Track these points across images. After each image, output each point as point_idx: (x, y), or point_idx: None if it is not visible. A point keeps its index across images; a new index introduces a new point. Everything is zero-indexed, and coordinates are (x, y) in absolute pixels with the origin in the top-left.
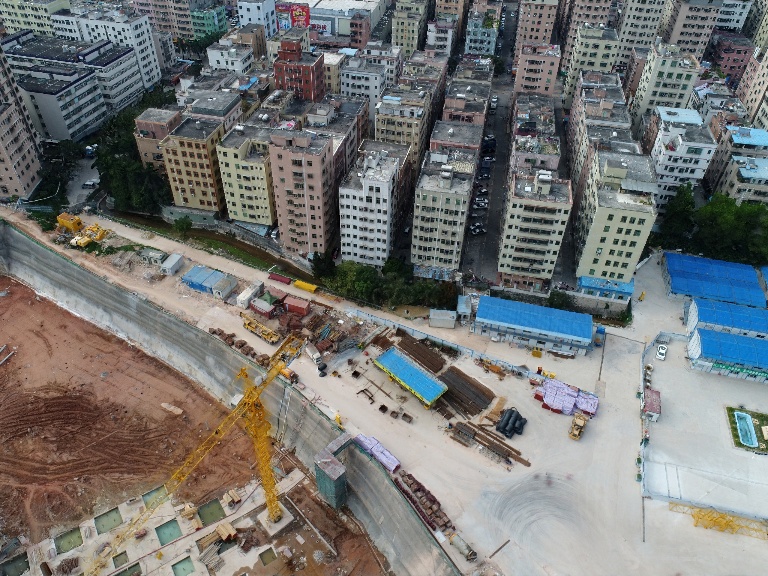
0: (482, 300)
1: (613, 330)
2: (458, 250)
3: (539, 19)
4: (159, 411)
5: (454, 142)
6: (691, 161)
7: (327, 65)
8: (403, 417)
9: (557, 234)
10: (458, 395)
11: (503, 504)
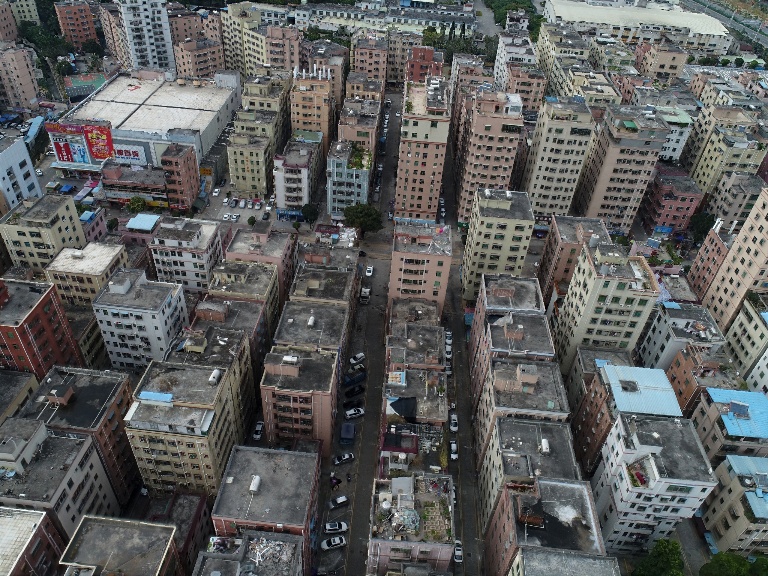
0: None
1: None
2: None
3: (423, 159)
4: None
5: (256, 521)
6: (673, 499)
7: (85, 275)
8: None
9: None
10: None
11: None
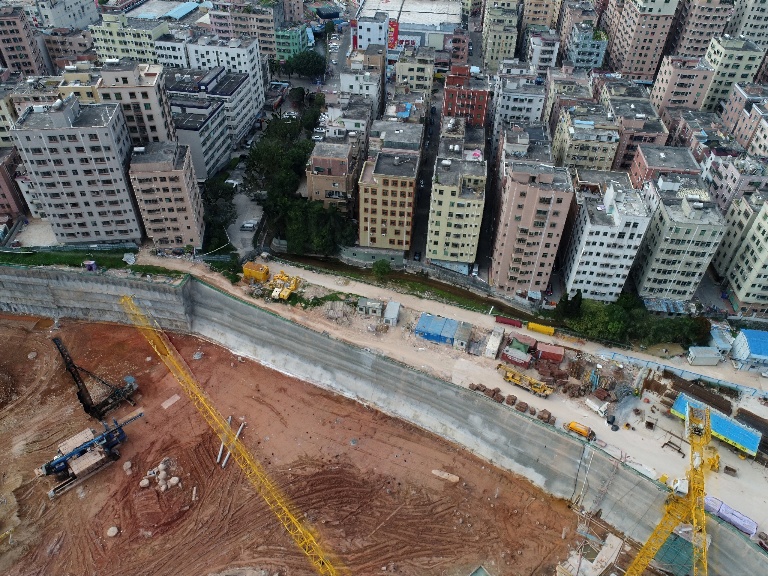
0: (748, 334)
1: None
2: (697, 281)
3: (653, 30)
4: (434, 480)
5: (674, 168)
6: None
7: None
8: (727, 471)
9: None
10: (766, 441)
11: None
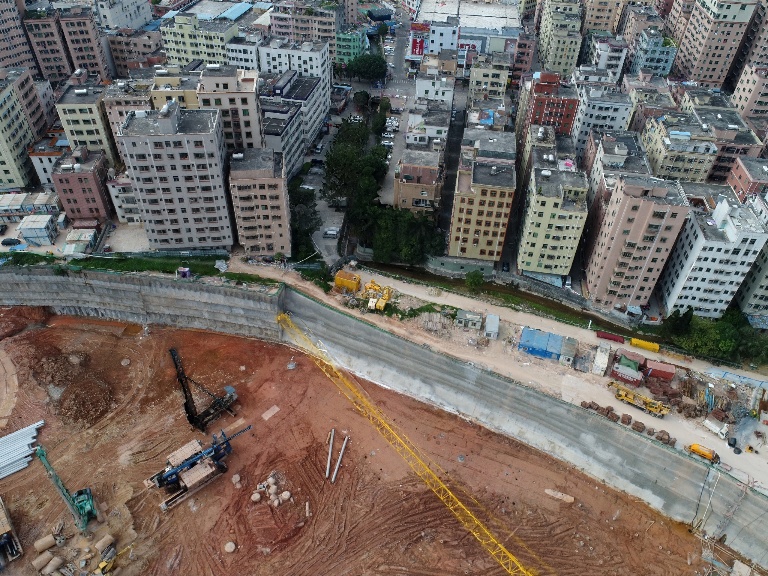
0: None
1: None
2: None
3: (726, 37)
4: (548, 500)
5: None
6: None
7: None
8: None
9: None
10: None
11: None
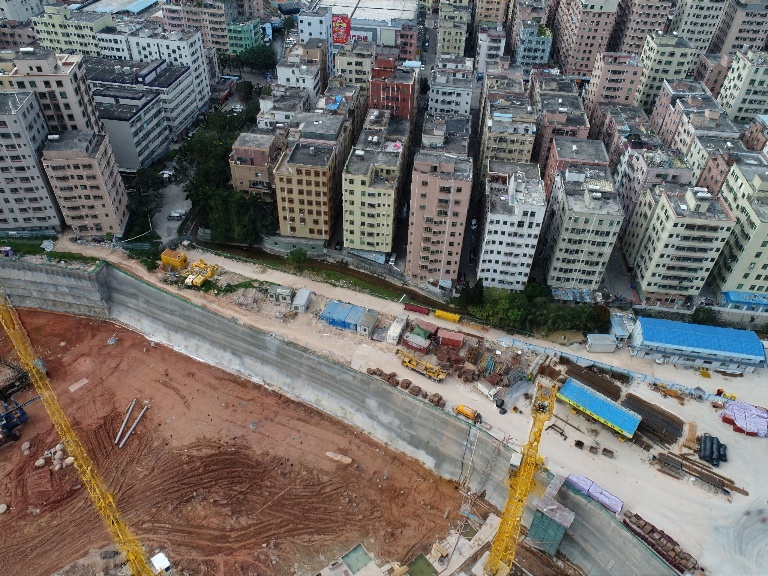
0: (643, 322)
1: (767, 344)
2: (601, 270)
3: (596, 27)
4: (326, 461)
5: (583, 159)
6: None
7: None
8: (604, 452)
9: (714, 251)
10: (648, 424)
11: (739, 538)
